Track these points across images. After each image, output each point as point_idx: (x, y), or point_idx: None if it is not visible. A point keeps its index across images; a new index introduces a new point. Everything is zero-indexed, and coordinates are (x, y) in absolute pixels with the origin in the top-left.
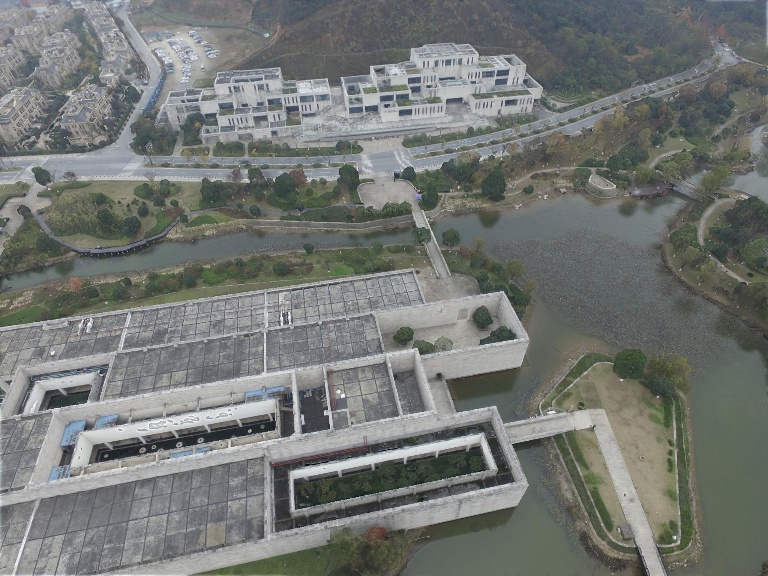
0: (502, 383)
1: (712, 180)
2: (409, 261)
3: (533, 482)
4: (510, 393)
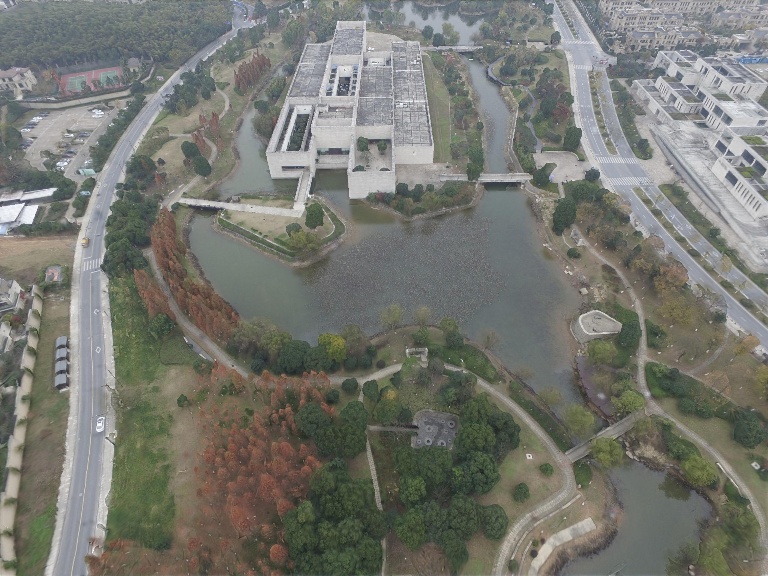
0: (342, 190)
1: (576, 414)
2: (462, 166)
3: (279, 187)
4: (333, 191)
